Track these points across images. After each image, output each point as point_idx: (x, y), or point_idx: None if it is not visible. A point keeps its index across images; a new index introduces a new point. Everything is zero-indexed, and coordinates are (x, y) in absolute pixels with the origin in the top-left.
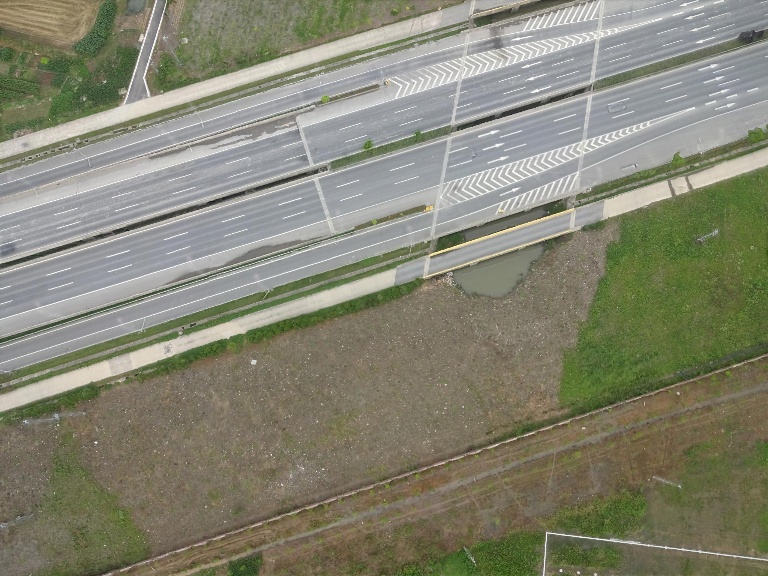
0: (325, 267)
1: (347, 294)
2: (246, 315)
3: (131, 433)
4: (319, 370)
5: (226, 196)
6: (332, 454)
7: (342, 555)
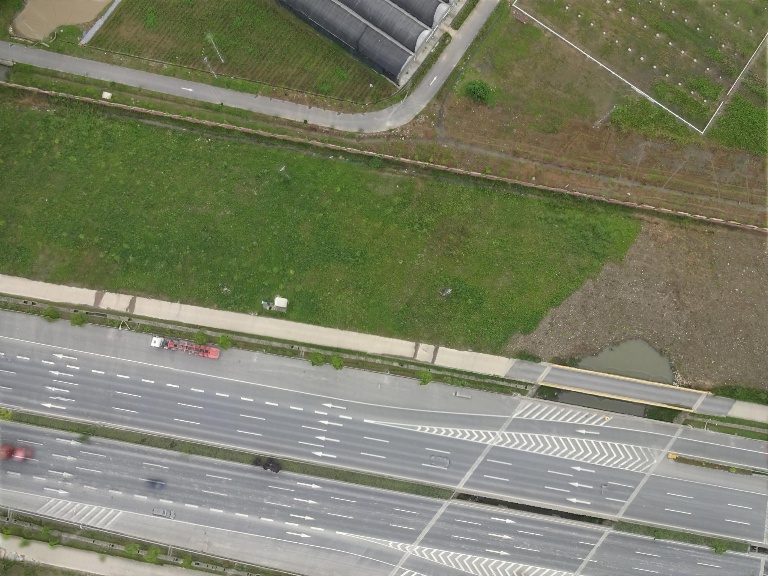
0: None
1: None
2: None
3: None
4: None
5: None
6: None
7: None
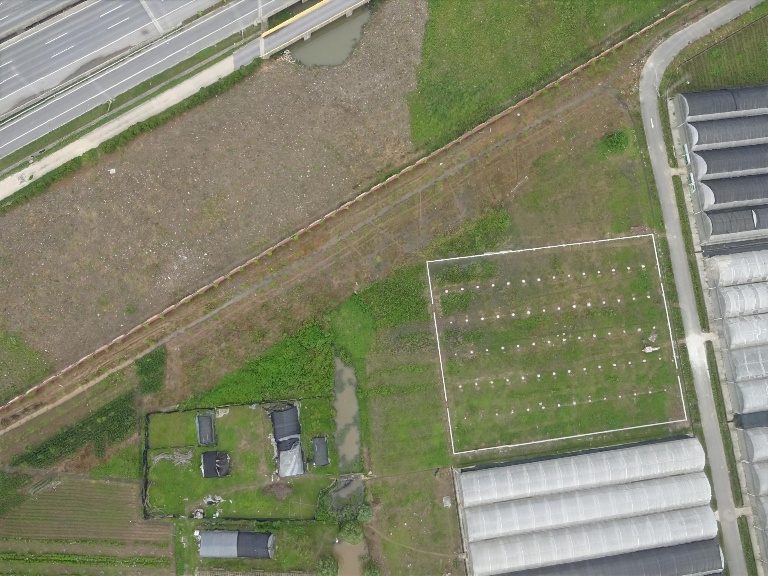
0: (162, 67)
1: (190, 89)
2: (94, 130)
3: (4, 264)
4: (179, 163)
5: (43, 19)
6: (210, 238)
7: (243, 327)
